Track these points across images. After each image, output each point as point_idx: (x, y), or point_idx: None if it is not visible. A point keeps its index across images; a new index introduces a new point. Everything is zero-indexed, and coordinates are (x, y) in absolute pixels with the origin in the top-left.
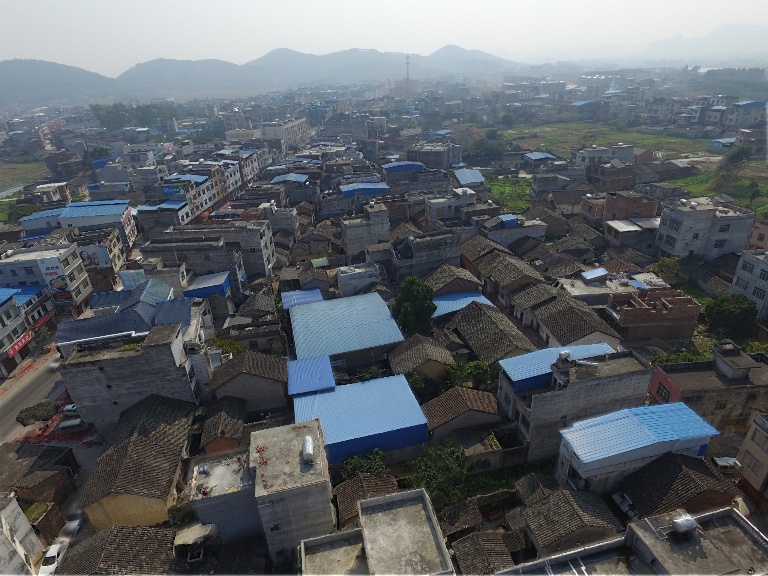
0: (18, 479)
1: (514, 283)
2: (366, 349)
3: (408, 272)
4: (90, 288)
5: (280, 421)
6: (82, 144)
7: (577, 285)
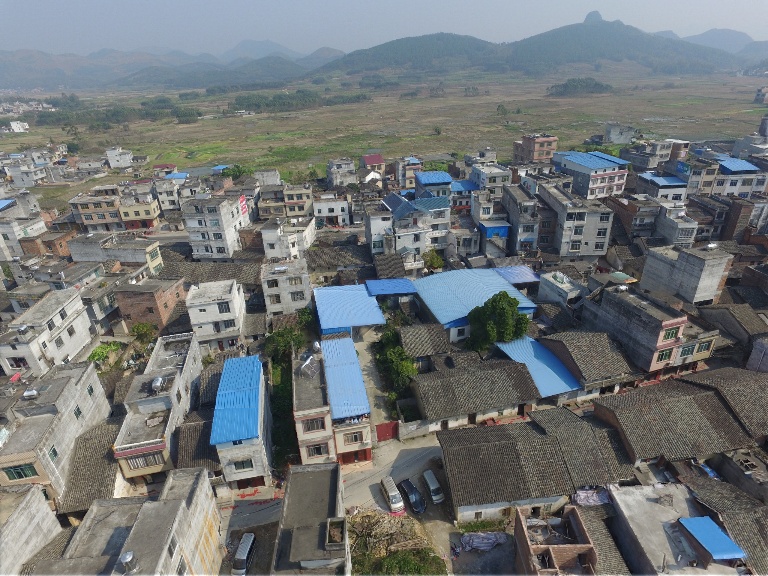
0: None
1: (602, 409)
2: None
3: (592, 320)
4: None
5: None
6: None
7: (661, 508)
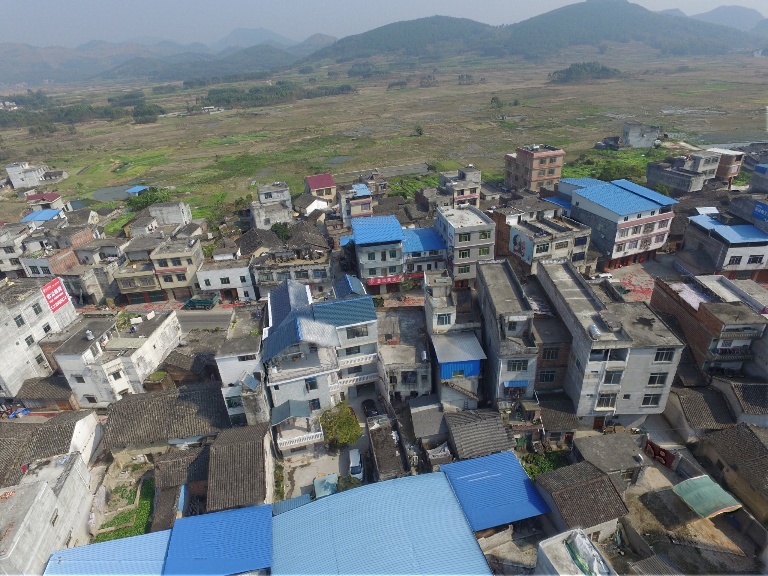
0: (200, 354)
1: None
2: None
3: None
4: None
5: (169, 526)
6: None
7: None
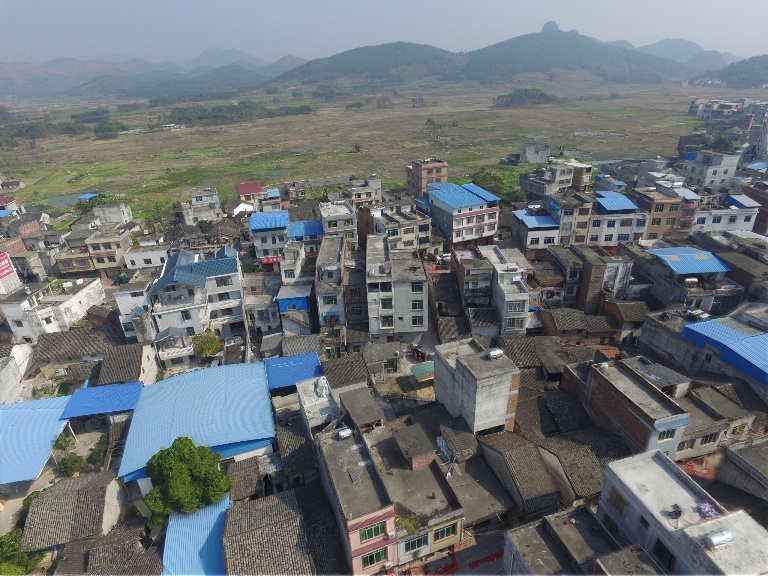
0: None
1: None
2: None
3: None
4: None
5: None
6: (760, 128)
7: None
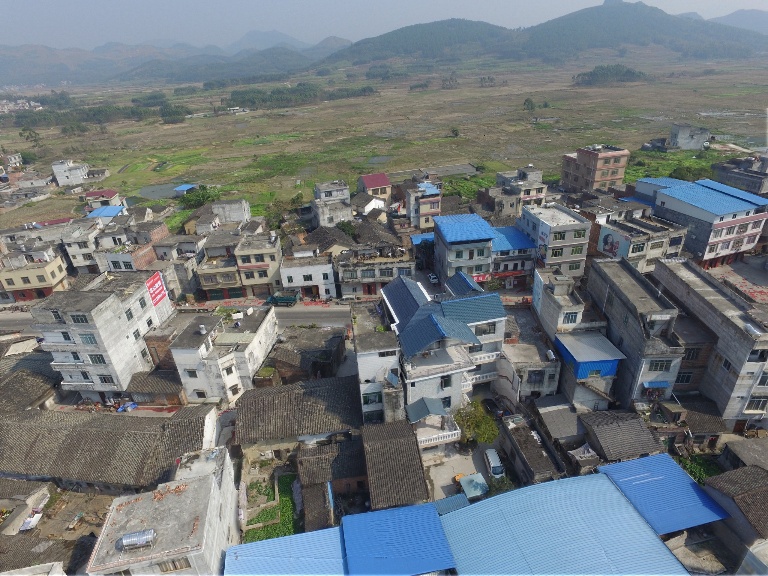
0: (303, 350)
1: None
2: None
3: None
4: (579, 273)
5: (326, 524)
6: None
7: None
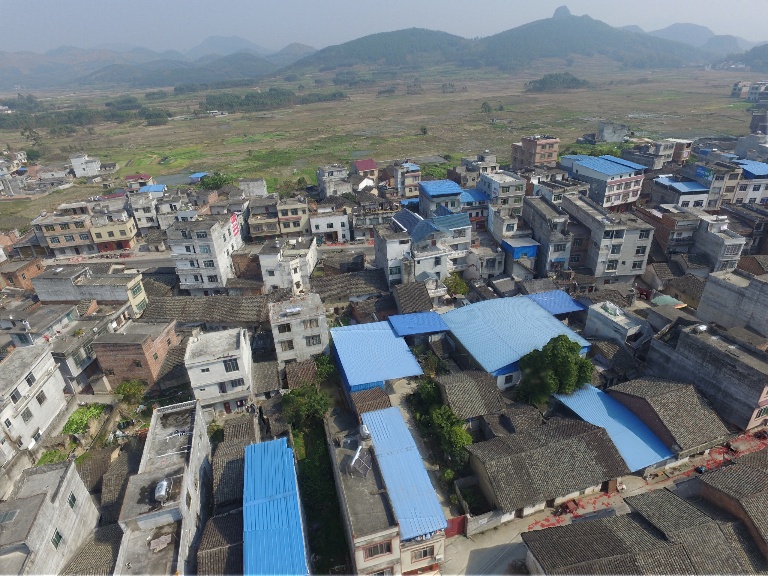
0: None
1: (716, 492)
2: (467, 350)
3: (662, 363)
4: None
5: None
6: None
7: None
